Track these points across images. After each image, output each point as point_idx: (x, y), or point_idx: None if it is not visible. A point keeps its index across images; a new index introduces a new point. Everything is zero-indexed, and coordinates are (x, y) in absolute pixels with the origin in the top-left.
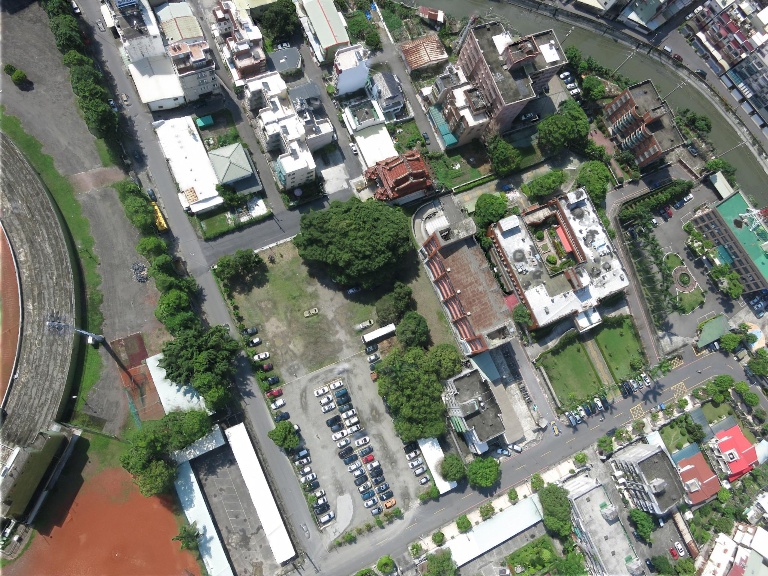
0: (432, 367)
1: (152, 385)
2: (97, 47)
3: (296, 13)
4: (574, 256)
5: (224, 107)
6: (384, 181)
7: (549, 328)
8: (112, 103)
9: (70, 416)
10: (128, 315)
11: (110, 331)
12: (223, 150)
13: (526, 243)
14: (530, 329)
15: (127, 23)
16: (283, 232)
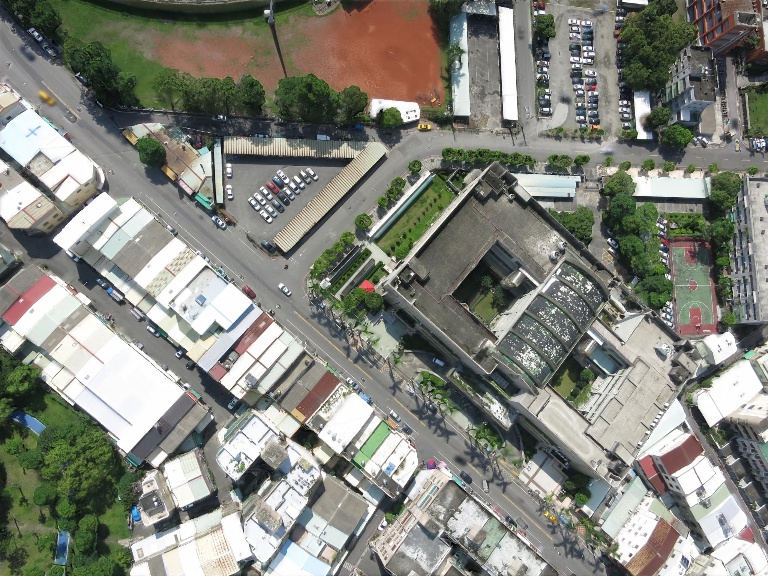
0: (677, 30)
1: None
2: None
3: None
4: None
5: None
6: None
7: (763, 68)
8: None
9: None
10: None
11: None
12: None
13: None
14: (749, 60)
15: None
16: None
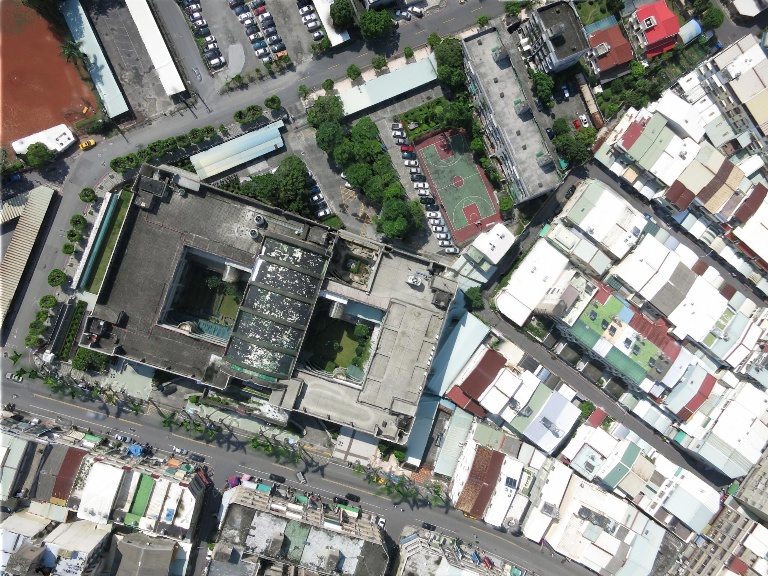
0: None
1: None
2: None
3: None
4: None
5: None
6: None
7: None
8: None
9: None
10: None
11: None
12: None
13: None
14: None
15: None
16: None
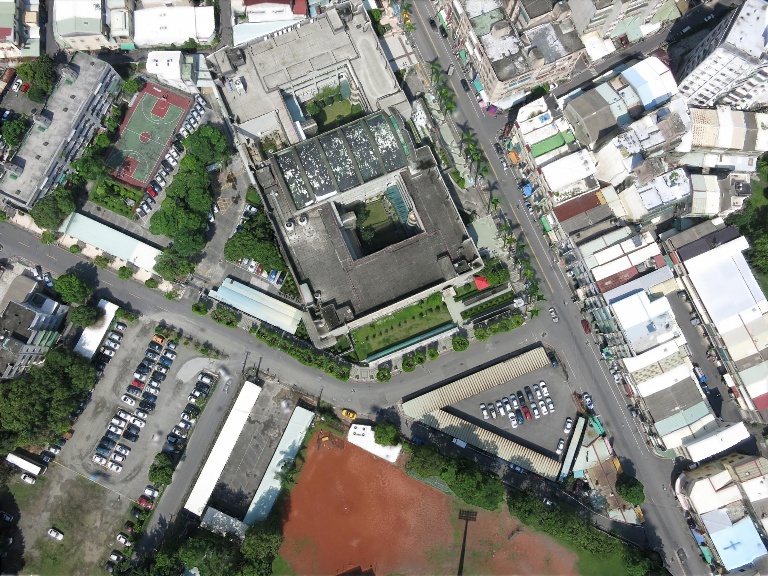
0: (5, 403)
1: None
2: None
3: None
4: None
5: None
6: None
7: None
8: None
9: None
10: None
11: None
12: None
13: None
14: None
15: None
16: None
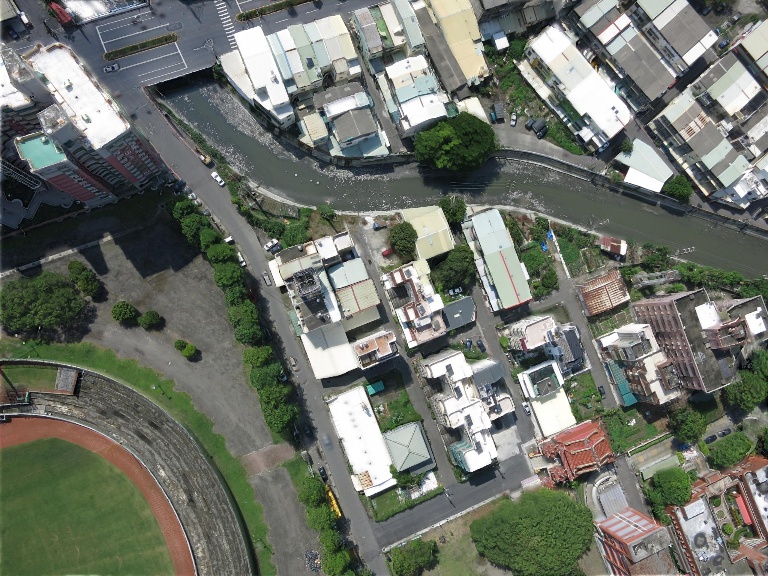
0: None
1: None
2: (264, 304)
3: (473, 260)
4: (753, 529)
5: (395, 370)
6: (564, 461)
7: None
8: (282, 372)
9: None
10: None
11: None
12: (401, 435)
13: (708, 525)
14: None
15: (309, 310)
16: (454, 507)
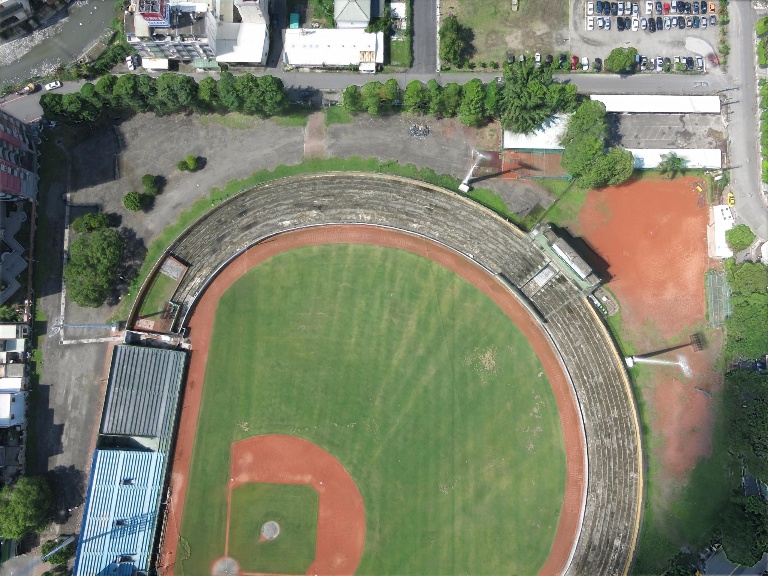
0: None
1: (524, 157)
2: None
3: None
4: None
5: None
6: None
7: None
8: None
9: (522, 229)
10: (453, 154)
11: (462, 173)
12: (338, 5)
13: None
14: None
15: (186, 27)
16: None
